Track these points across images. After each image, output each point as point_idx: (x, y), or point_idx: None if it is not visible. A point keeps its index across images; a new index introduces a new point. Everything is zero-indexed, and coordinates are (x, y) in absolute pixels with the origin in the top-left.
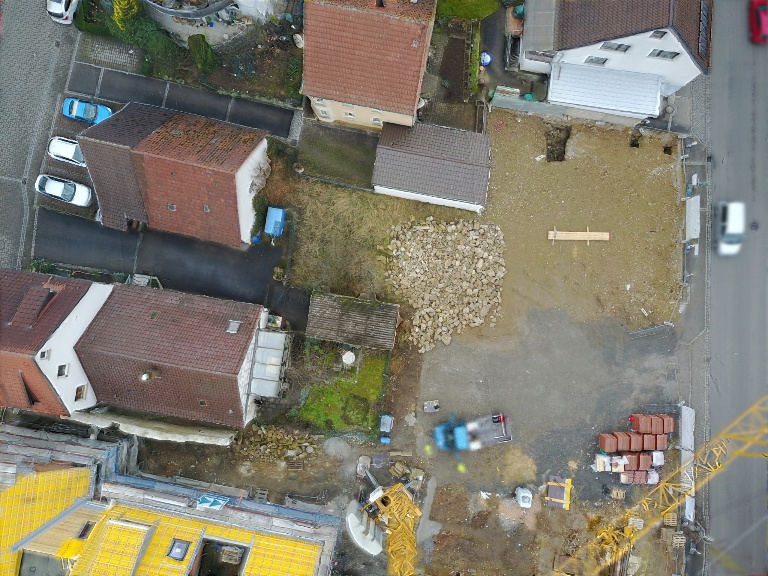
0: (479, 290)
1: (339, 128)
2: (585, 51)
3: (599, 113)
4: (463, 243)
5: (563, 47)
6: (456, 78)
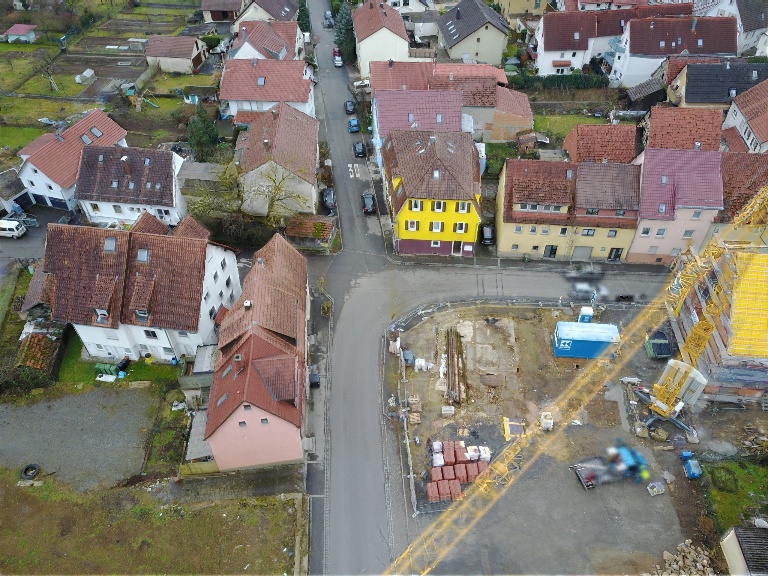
0: None
1: None
2: None
3: None
4: None
5: None
6: None
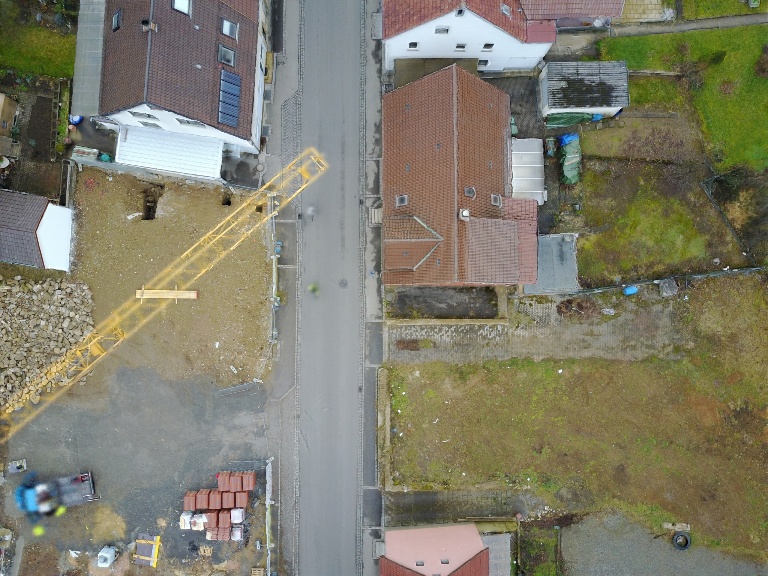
0: (67, 349)
1: None
2: (127, 117)
3: None
4: (48, 303)
5: (102, 113)
6: (43, 137)
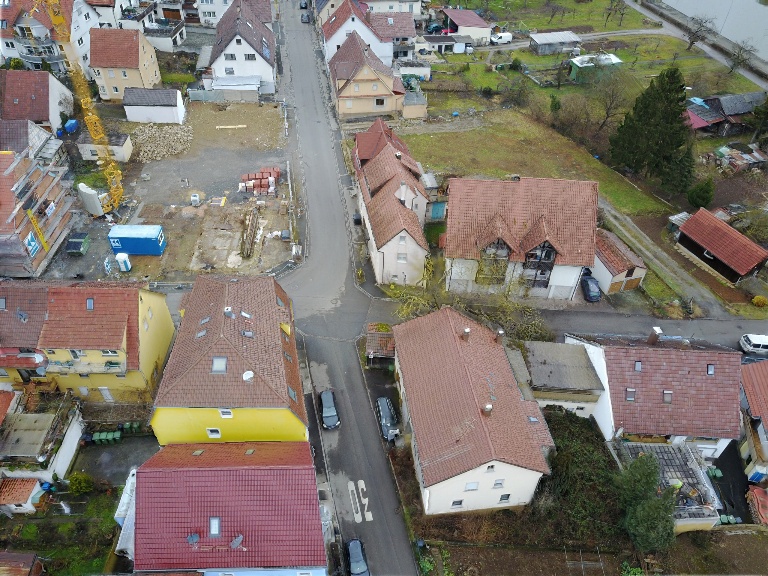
0: None
1: (113, 105)
2: (221, 64)
3: (238, 92)
4: None
5: (211, 62)
6: None
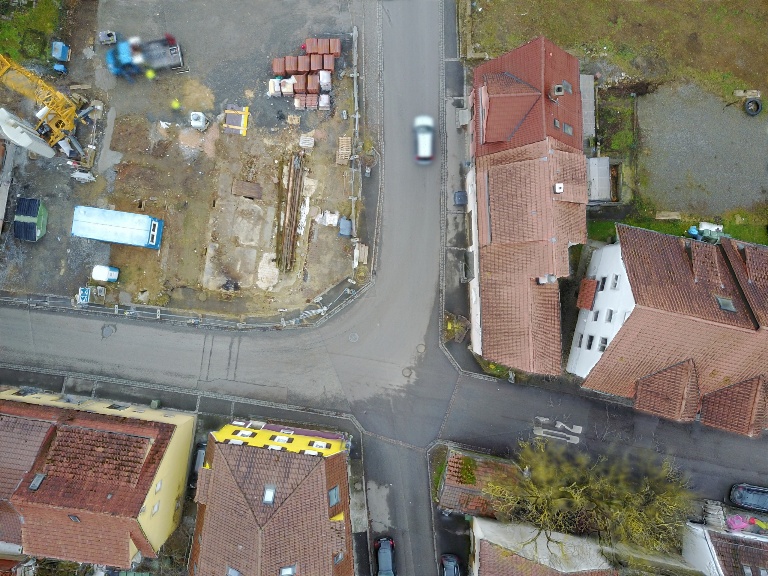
0: None
1: None
2: None
3: None
4: None
5: None
6: None
